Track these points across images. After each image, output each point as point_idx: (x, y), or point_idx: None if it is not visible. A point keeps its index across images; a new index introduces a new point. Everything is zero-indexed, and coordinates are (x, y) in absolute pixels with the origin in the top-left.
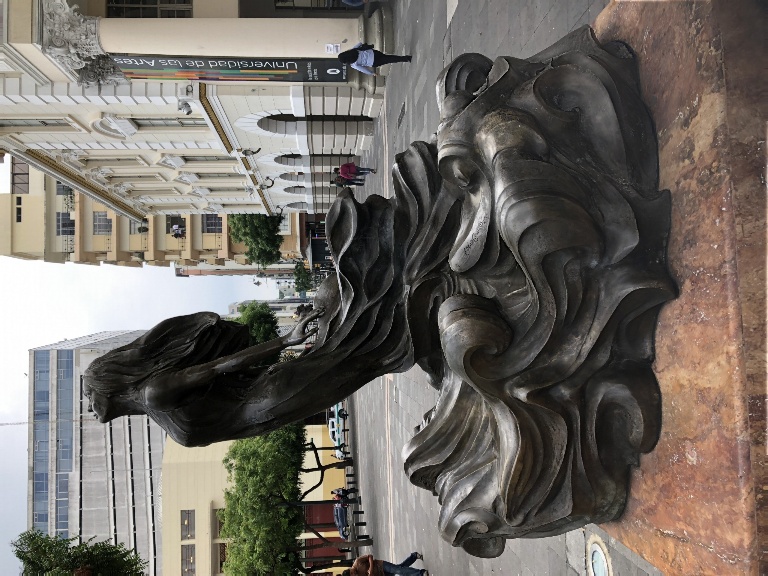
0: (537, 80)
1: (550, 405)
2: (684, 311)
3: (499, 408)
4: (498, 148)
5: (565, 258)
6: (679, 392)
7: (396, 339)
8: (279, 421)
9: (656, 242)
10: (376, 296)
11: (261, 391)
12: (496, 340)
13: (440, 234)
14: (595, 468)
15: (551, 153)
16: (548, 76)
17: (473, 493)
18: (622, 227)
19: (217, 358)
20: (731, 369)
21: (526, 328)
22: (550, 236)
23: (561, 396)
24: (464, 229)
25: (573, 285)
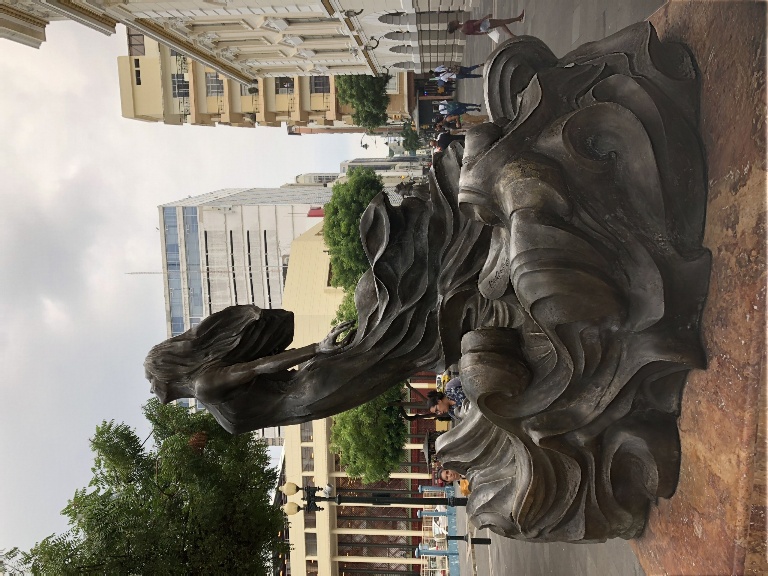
0: (568, 122)
1: (564, 449)
2: (708, 387)
3: (515, 442)
4: (515, 207)
5: (581, 325)
6: (695, 462)
7: (429, 344)
8: (316, 416)
9: (690, 306)
10: (411, 300)
11: (300, 387)
12: (511, 386)
13: (475, 246)
14: (610, 503)
15: (575, 211)
16: (582, 115)
17: (494, 500)
18: (648, 295)
19: (262, 349)
20: (739, 474)
21: (545, 372)
22: (562, 309)
23: (576, 442)
24: (490, 261)
25: (591, 346)
